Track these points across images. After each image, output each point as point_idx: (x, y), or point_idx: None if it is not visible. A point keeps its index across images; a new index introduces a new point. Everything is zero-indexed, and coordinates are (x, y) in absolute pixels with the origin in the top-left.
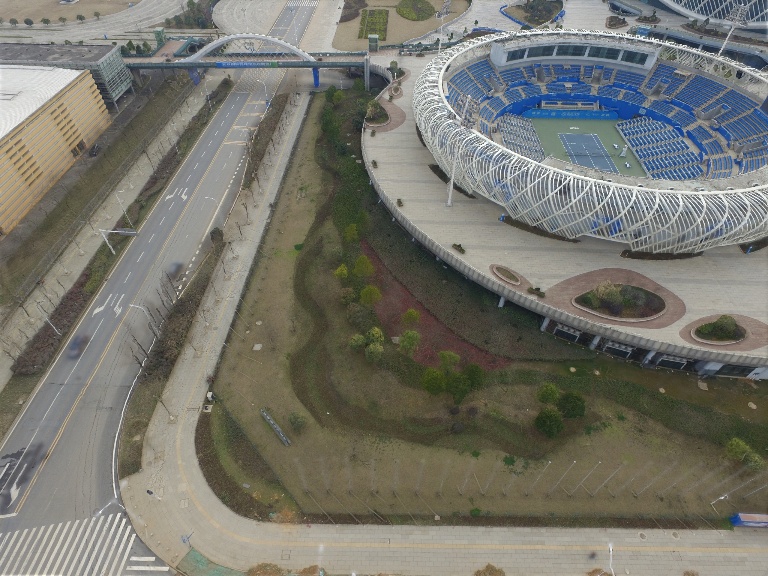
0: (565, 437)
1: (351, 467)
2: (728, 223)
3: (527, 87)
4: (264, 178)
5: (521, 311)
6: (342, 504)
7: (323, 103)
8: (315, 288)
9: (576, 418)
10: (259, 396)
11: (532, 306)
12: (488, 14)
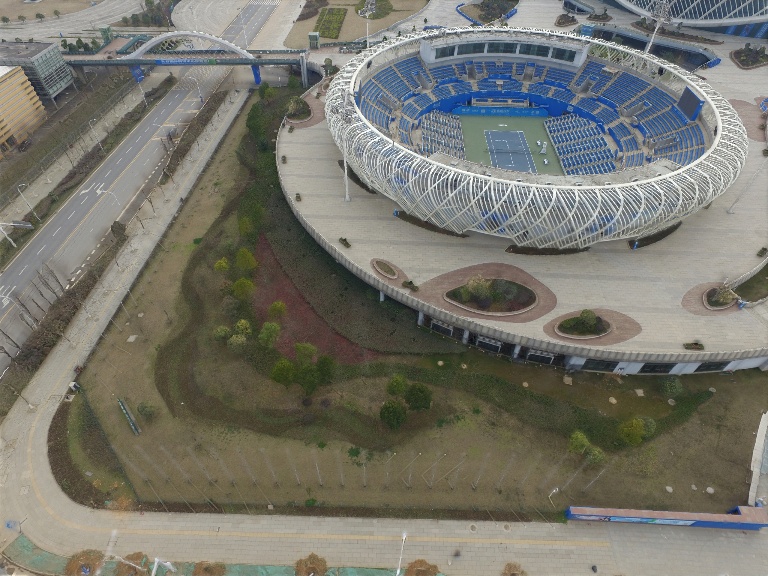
0: (415, 429)
1: (194, 456)
2: (600, 218)
3: (457, 84)
4: (182, 173)
5: (400, 305)
6: (179, 493)
7: (259, 100)
8: (201, 281)
9: (430, 411)
10: (121, 386)
11: (403, 300)
12: (443, 12)
